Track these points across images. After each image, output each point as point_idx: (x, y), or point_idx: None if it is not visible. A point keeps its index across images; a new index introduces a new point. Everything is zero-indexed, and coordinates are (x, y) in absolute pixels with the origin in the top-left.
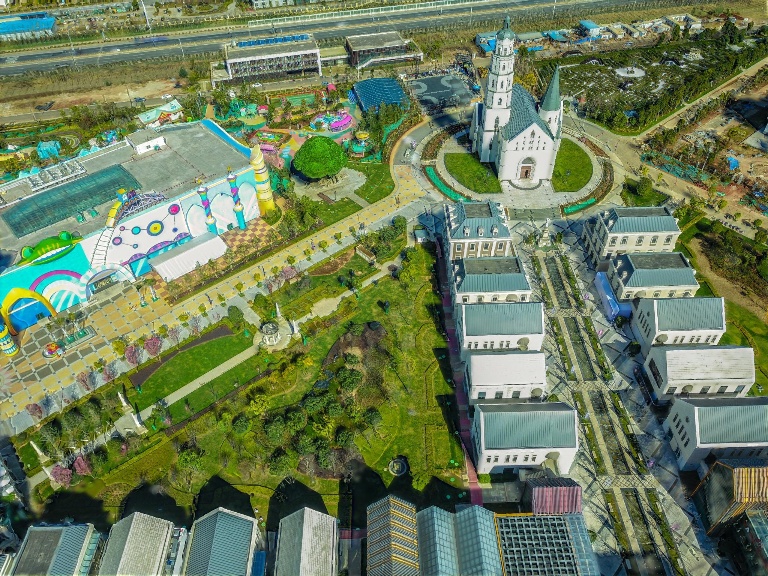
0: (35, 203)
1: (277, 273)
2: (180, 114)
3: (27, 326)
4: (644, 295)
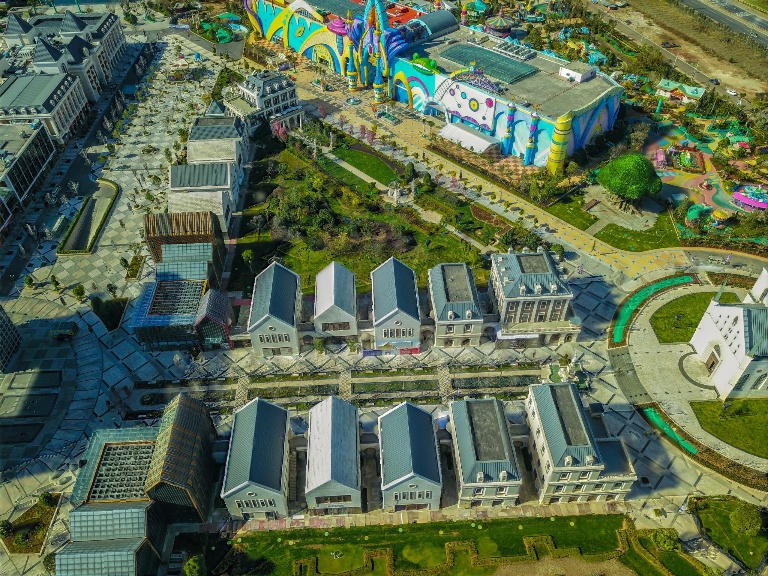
0: (476, 51)
1: (470, 189)
2: (691, 101)
3: (400, 101)
4: (448, 429)
